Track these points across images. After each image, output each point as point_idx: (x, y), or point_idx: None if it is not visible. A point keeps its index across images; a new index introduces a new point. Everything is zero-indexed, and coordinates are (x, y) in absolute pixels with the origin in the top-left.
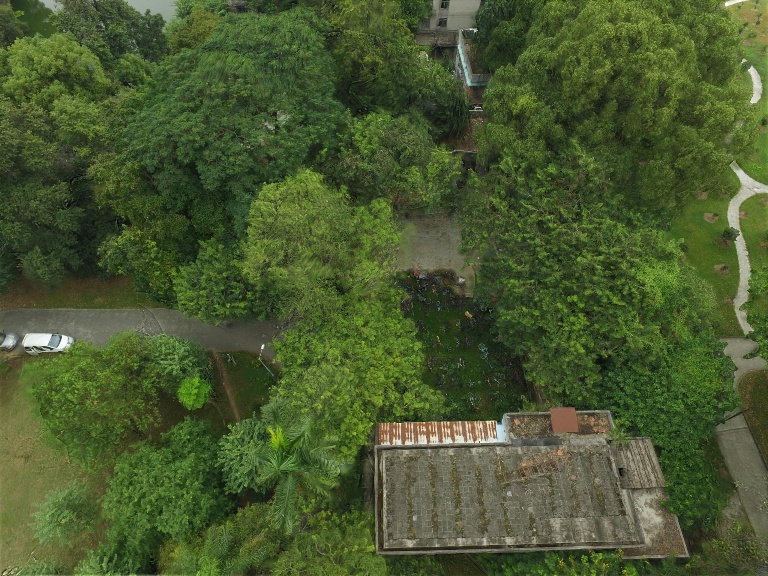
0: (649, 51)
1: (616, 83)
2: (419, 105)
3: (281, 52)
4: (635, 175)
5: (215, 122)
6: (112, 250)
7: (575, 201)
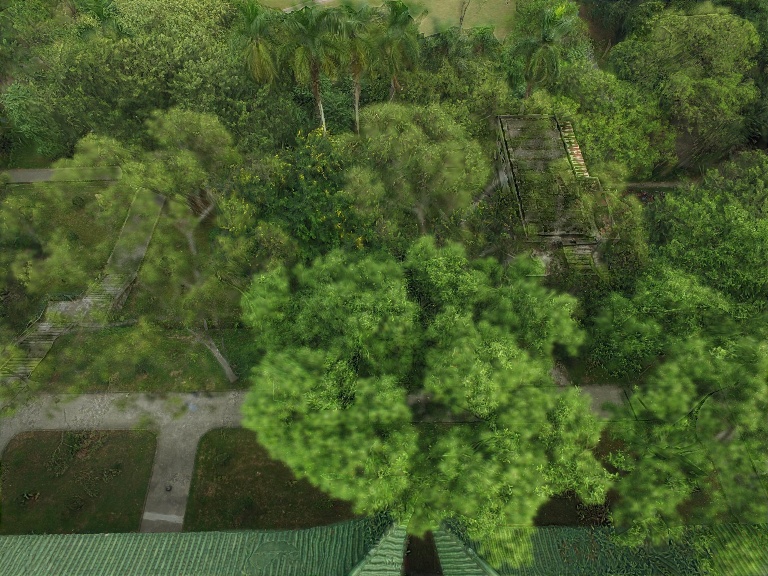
0: None
1: None
2: None
3: None
4: None
5: None
6: (643, 6)
7: None
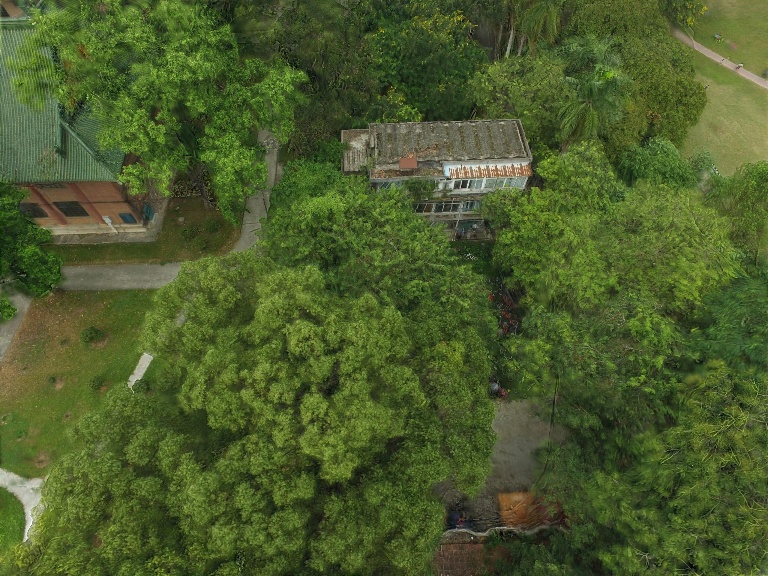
0: (293, 325)
1: None
2: (579, 575)
3: None
4: None
5: None
6: None
7: None
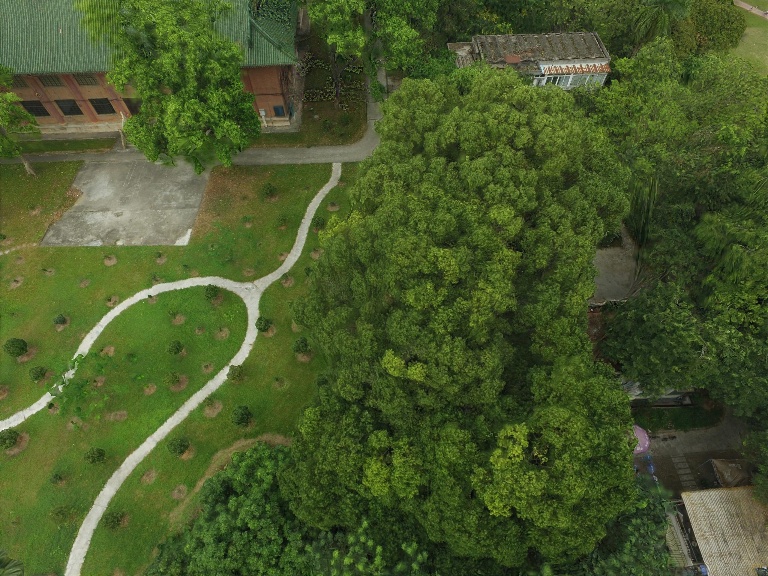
0: None
1: None
2: None
3: None
4: None
5: None
6: None
7: None
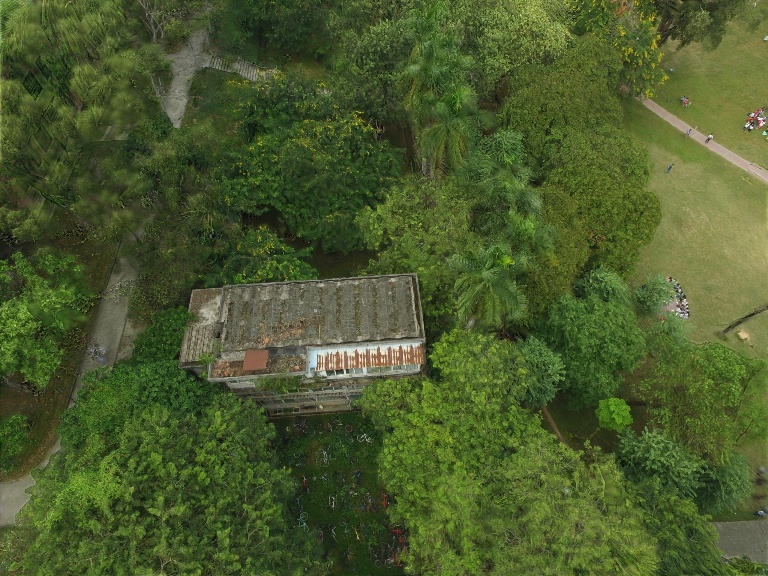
0: None
1: None
2: None
3: None
4: None
5: None
6: None
7: None
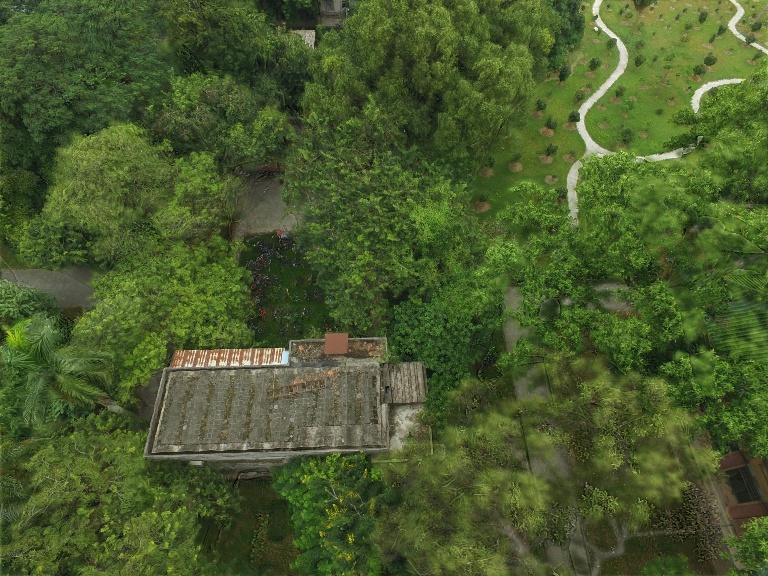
0: (427, 11)
1: (397, 40)
2: (277, 74)
3: (97, 12)
4: (435, 129)
5: (31, 76)
6: None
7: (370, 150)
